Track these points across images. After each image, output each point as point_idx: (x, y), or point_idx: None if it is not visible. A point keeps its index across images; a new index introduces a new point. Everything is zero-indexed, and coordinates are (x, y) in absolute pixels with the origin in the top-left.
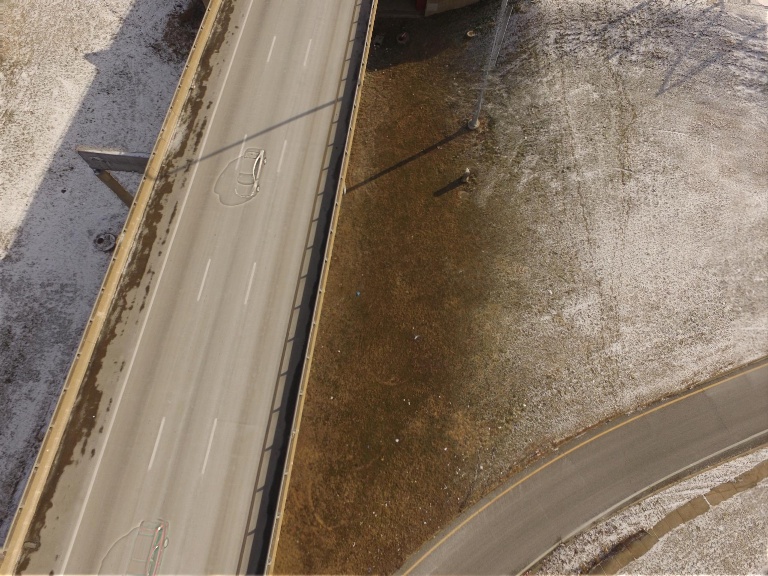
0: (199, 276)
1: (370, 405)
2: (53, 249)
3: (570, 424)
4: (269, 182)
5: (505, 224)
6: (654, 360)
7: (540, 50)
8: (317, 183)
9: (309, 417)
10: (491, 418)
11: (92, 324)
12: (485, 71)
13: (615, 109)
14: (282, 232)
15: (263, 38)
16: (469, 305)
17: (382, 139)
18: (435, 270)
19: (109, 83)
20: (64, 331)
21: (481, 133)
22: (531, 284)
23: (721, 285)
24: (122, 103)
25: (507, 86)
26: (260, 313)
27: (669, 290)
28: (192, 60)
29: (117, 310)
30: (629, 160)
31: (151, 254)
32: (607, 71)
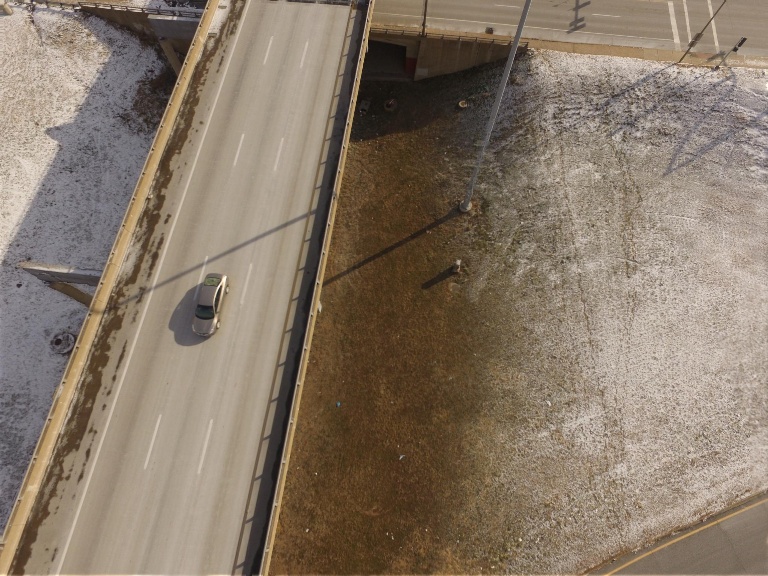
0: (147, 437)
1: (349, 540)
2: (5, 354)
3: (571, 564)
4: (231, 316)
5: (499, 322)
6: (663, 485)
7: (537, 126)
8: (285, 317)
9: (282, 554)
10: (483, 556)
11: (21, 503)
12: (478, 147)
13: (619, 191)
14: (244, 380)
15: (230, 136)
16: (459, 419)
17: (367, 221)
18: (423, 377)
19: (72, 160)
20: (14, 450)
21: (474, 216)
22: (528, 394)
23: (735, 394)
24: (86, 182)
25: (502, 164)
26: (215, 485)
27: (679, 400)
28: (150, 165)
29: (52, 480)
30: (634, 249)
31: (94, 408)
32: (610, 149)
